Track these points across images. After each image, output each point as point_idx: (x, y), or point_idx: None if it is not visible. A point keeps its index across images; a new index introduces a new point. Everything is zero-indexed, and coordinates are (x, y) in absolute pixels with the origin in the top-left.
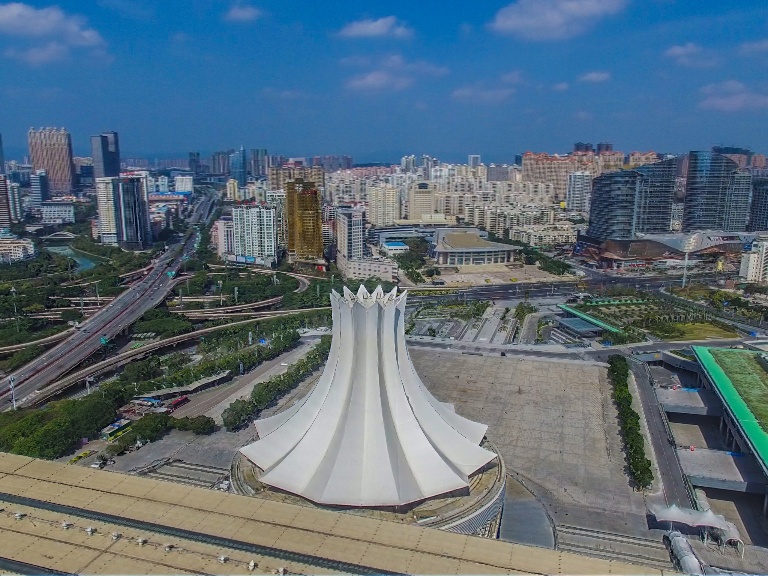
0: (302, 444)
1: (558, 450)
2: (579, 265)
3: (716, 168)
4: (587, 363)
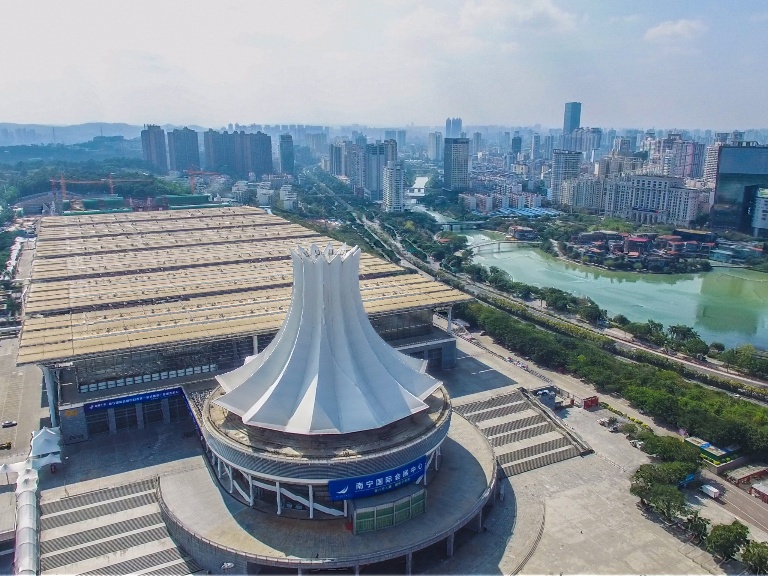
0: None
1: None
2: None
3: None
4: None
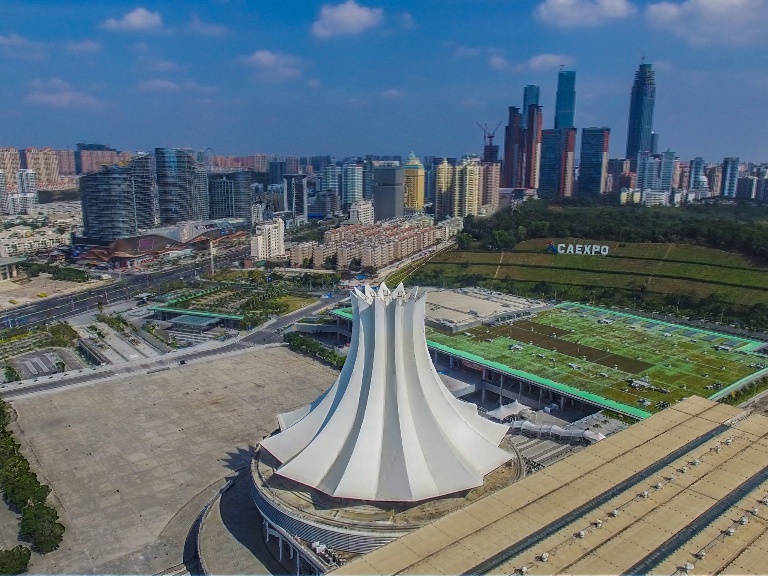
0: (407, 453)
1: None
2: (88, 269)
3: (181, 164)
4: (258, 348)
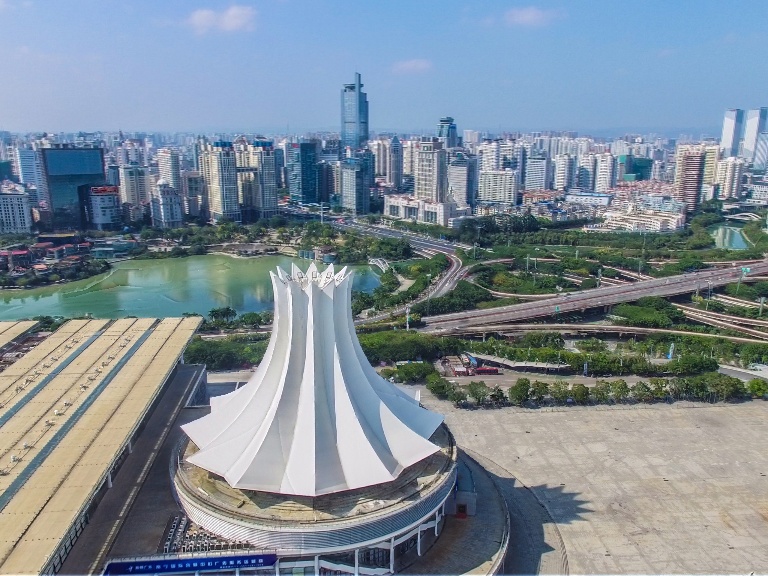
0: None
1: None
2: None
3: None
4: None
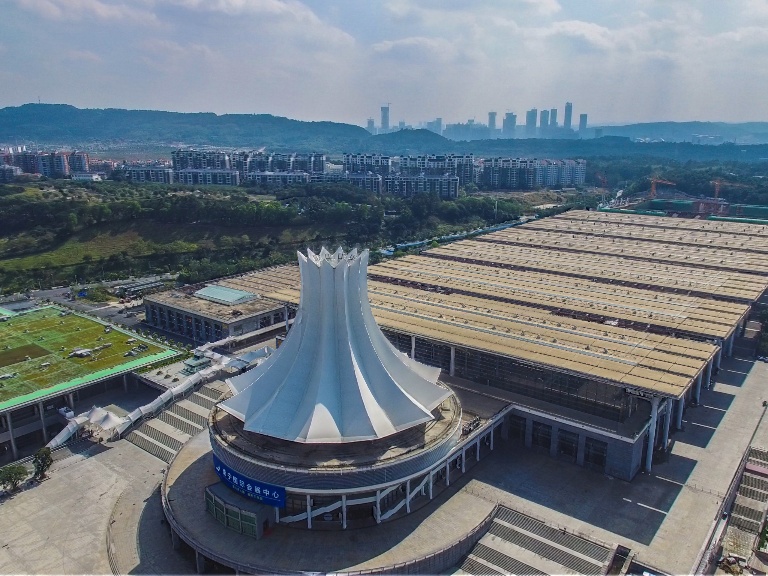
0: None
1: (2, 550)
2: None
3: None
4: None
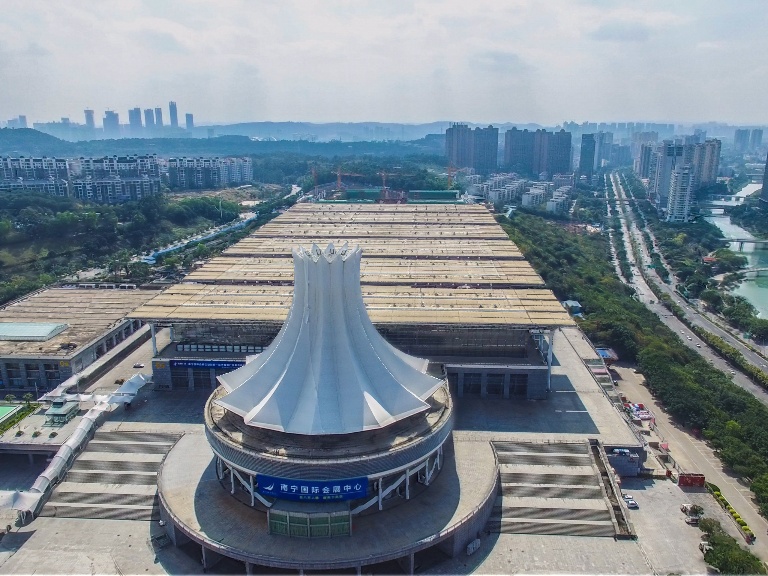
0: None
1: None
2: None
3: None
4: None
